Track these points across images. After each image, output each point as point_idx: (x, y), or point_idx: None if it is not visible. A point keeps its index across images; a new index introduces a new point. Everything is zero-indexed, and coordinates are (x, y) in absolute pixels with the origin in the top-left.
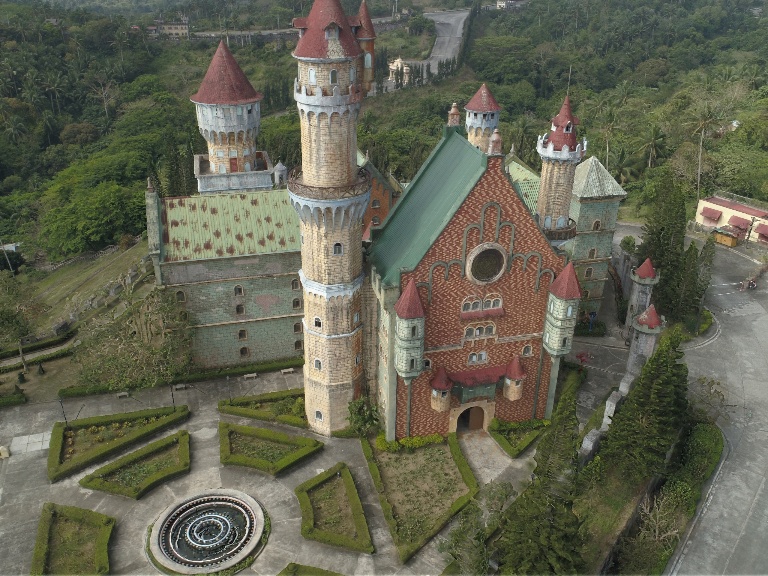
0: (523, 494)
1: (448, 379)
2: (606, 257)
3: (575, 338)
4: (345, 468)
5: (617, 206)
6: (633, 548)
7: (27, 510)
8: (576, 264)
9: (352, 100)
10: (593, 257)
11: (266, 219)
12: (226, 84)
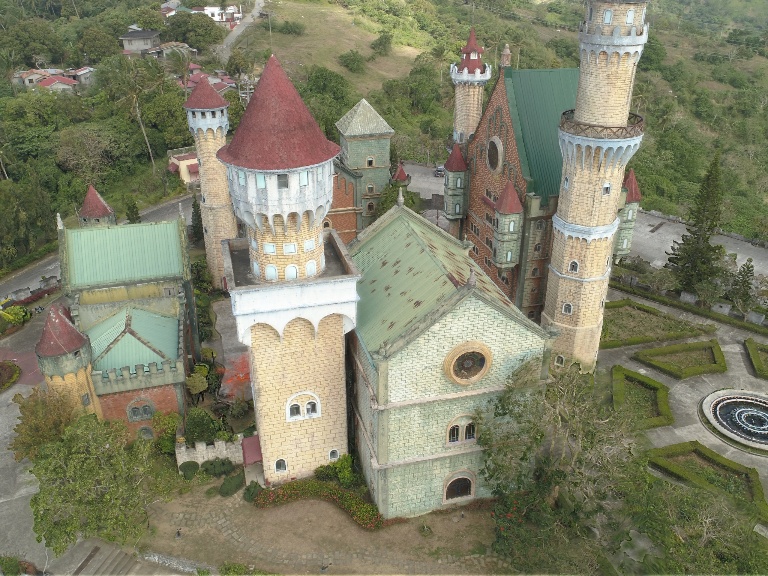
0: (680, 253)
1: None
2: None
3: None
4: None
5: None
6: (642, 264)
7: None
8: None
9: None
10: None
11: (450, 255)
12: None
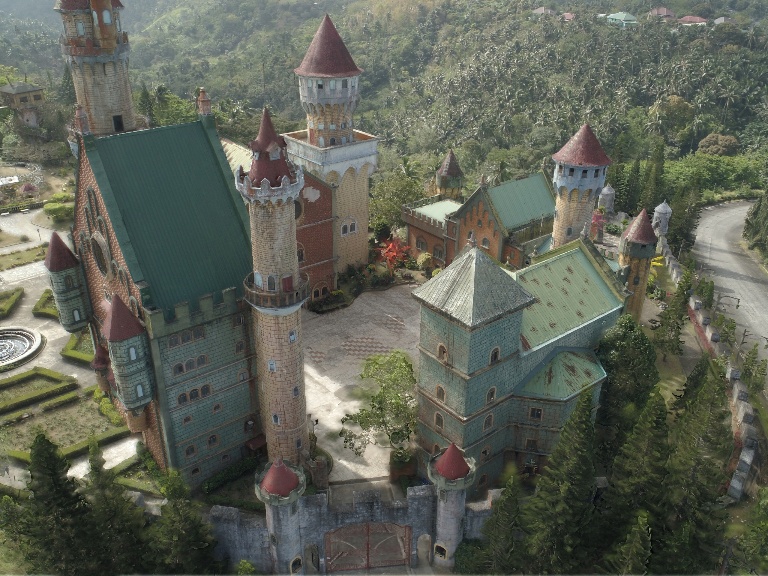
0: None
1: (101, 359)
2: (457, 413)
3: (398, 494)
4: (68, 382)
5: (468, 339)
6: None
7: (24, 287)
8: (154, 310)
9: (74, 52)
10: (443, 400)
11: None
12: (310, 55)
